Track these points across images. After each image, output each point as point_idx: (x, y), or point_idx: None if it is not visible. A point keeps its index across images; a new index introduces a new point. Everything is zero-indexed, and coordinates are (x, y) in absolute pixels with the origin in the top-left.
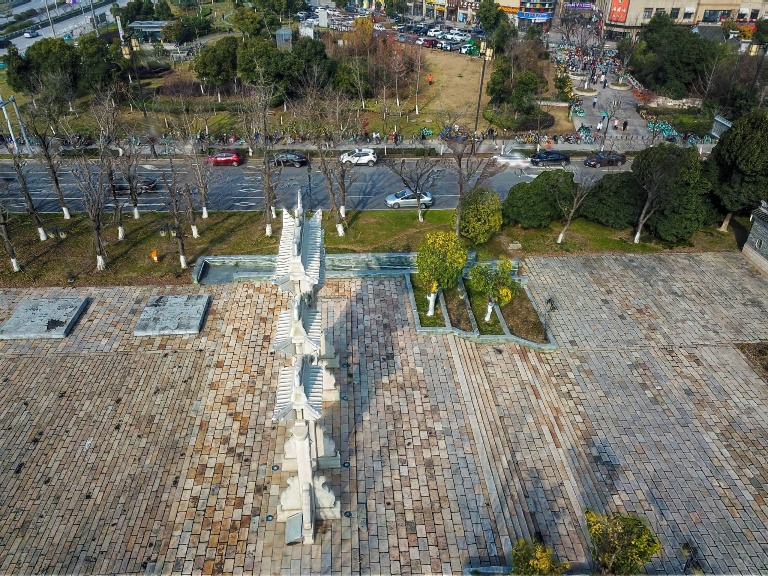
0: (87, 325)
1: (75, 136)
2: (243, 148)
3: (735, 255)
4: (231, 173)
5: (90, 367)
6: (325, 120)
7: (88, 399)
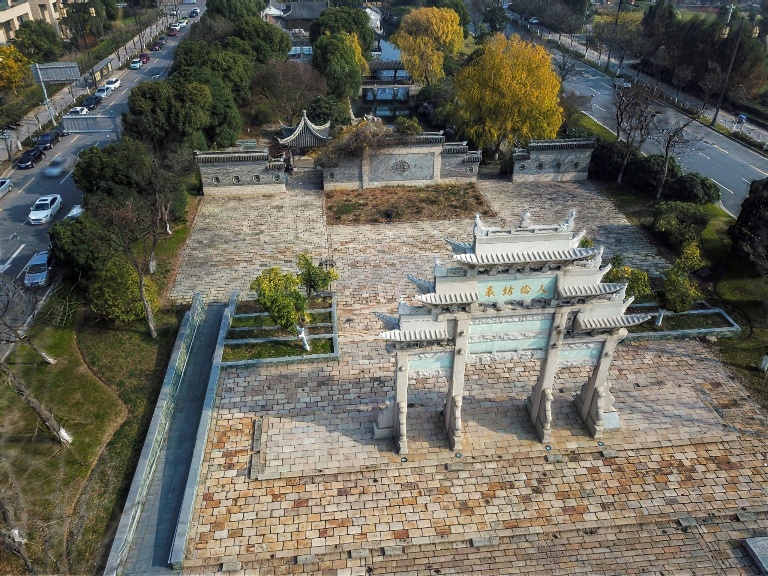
0: None
1: None
2: None
3: (207, 199)
4: None
5: None
6: None
7: None
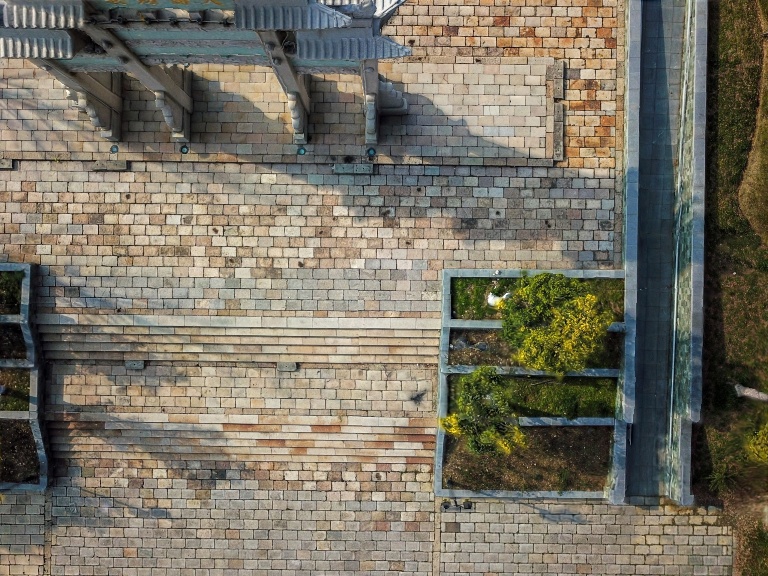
0: None
1: None
2: None
3: None
4: None
5: None
6: None
7: None
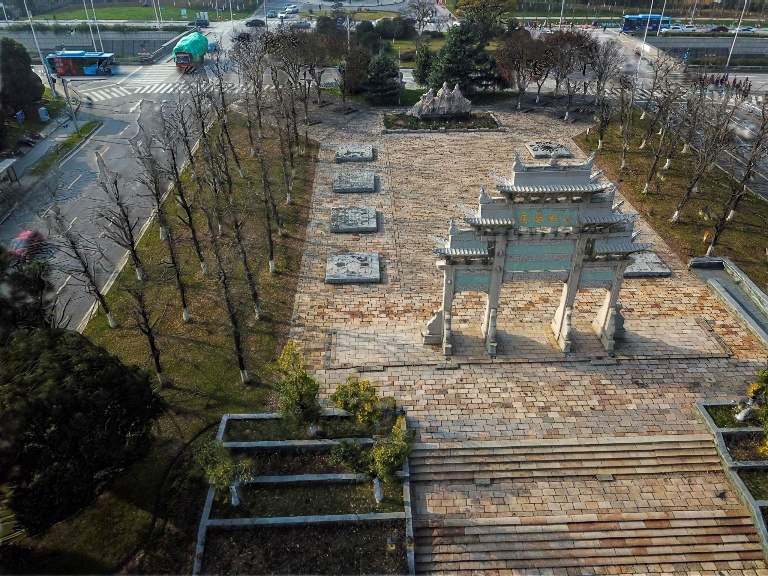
0: None
1: None
2: None
3: None
4: None
5: None
6: None
7: None
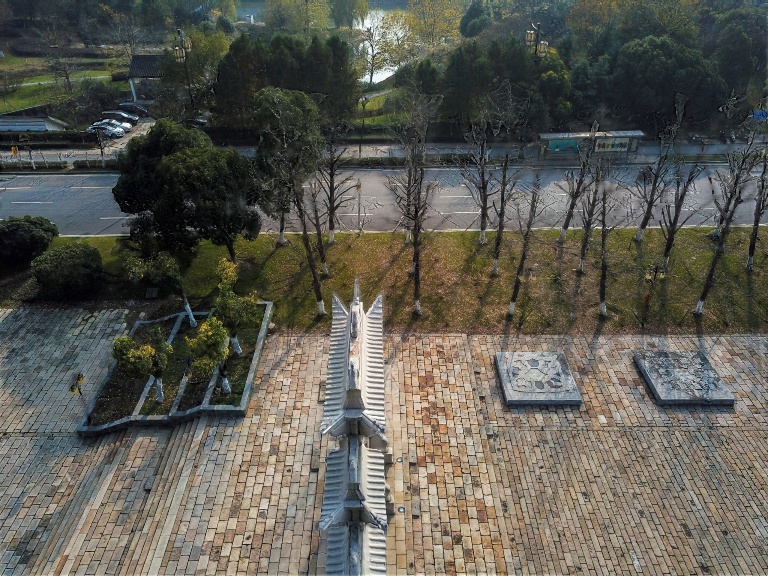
0: None
1: None
2: None
3: None
4: None
5: None
6: None
7: None
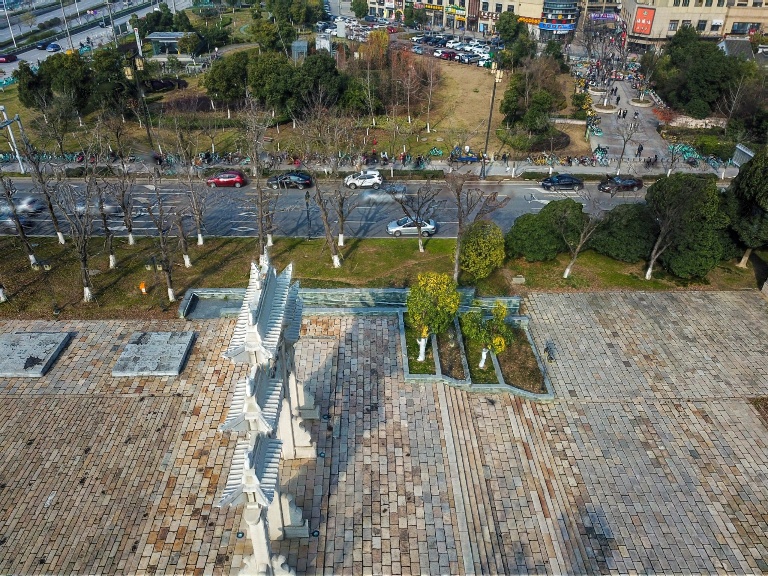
0: (66, 363)
1: (60, 168)
2: (247, 168)
3: (754, 295)
4: (233, 195)
5: (63, 411)
6: (323, 147)
7: (57, 447)
